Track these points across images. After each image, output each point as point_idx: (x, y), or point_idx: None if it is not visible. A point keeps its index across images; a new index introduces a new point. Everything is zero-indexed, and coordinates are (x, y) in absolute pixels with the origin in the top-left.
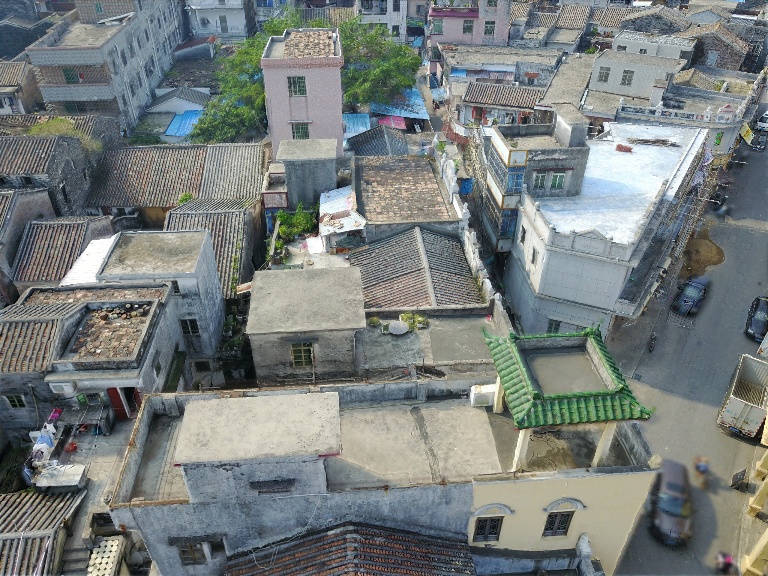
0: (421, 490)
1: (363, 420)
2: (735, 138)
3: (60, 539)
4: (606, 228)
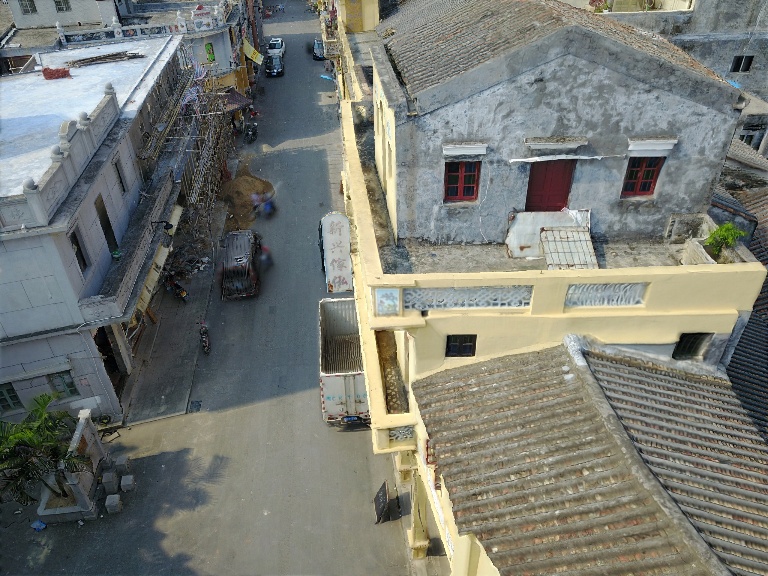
0: None
1: None
2: (235, 54)
3: None
4: (8, 184)
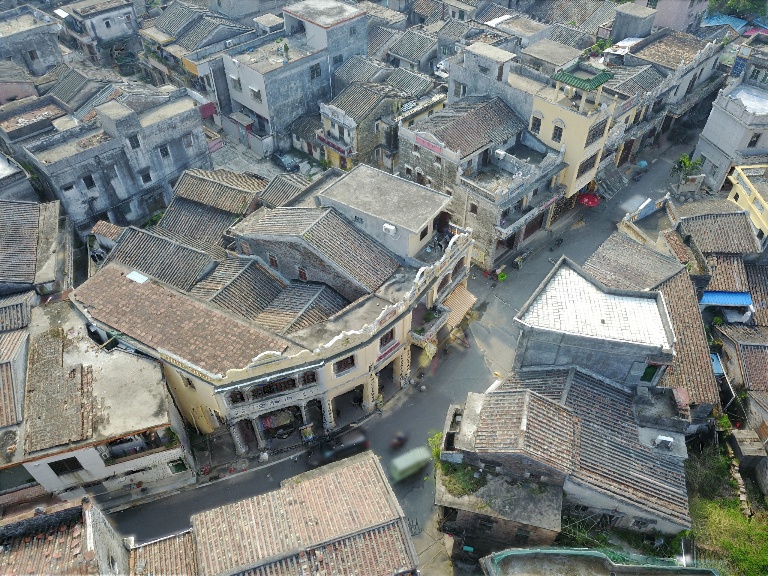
0: (519, 92)
1: (527, 81)
2: None
3: (431, 86)
4: (765, 111)
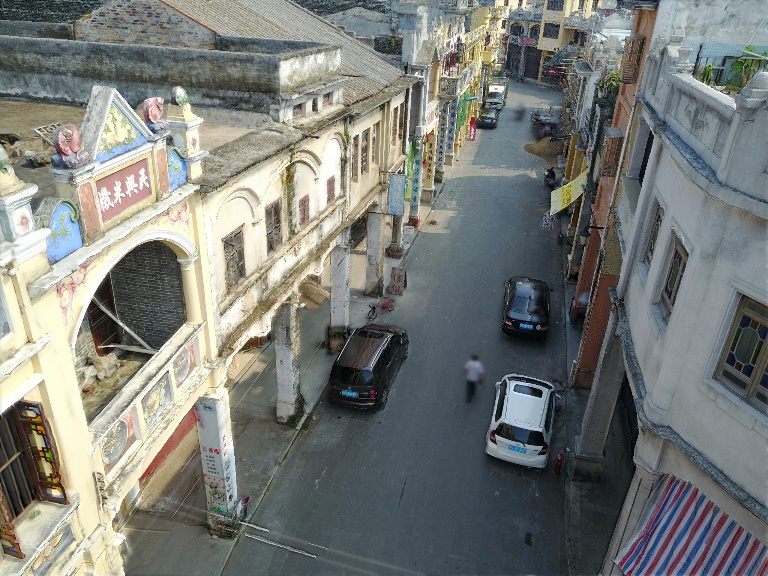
0: None
1: None
2: None
3: None
4: None
